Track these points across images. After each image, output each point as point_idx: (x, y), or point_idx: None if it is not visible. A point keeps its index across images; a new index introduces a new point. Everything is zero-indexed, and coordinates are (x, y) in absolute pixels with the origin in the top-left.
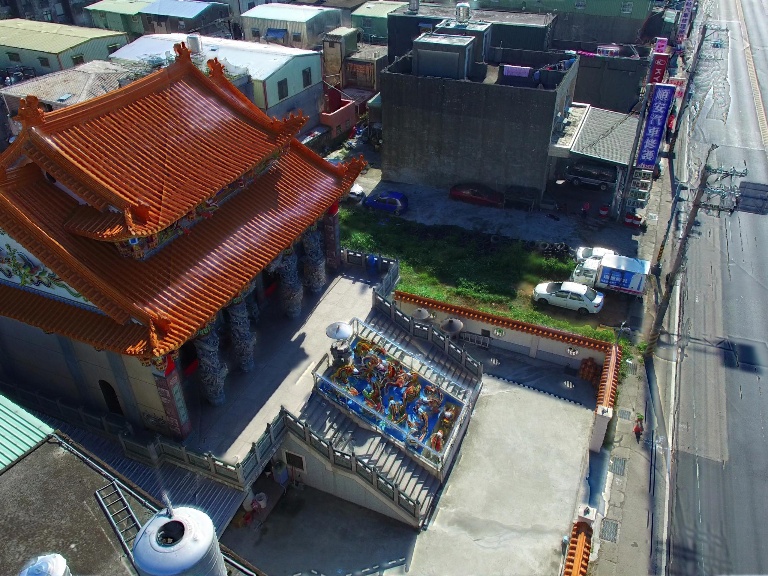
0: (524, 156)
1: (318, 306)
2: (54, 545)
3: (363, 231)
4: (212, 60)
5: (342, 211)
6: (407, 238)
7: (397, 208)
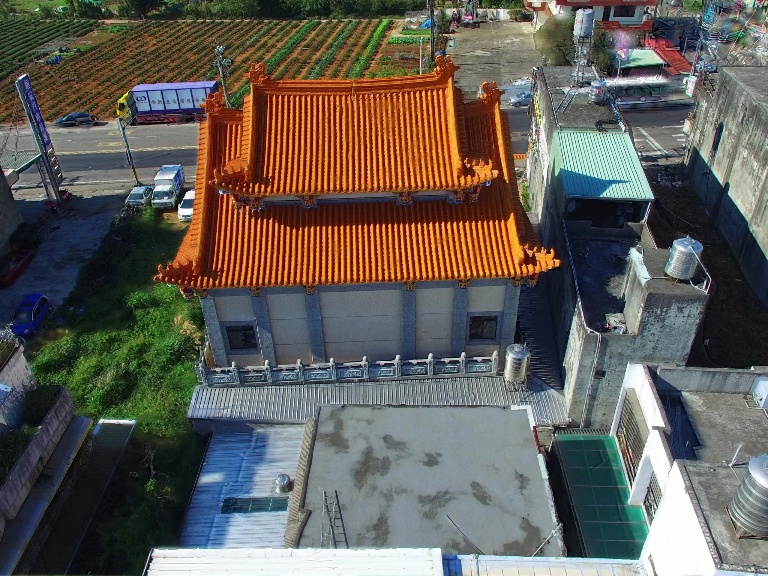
0: (0, 202)
1: None
2: None
3: (103, 316)
4: None
5: (51, 345)
6: (111, 290)
7: (49, 304)
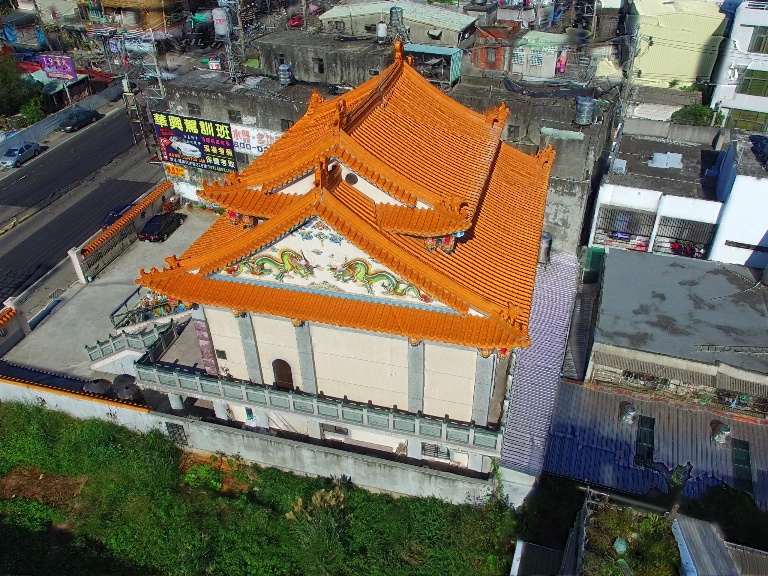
0: None
1: None
2: (299, 91)
3: None
4: (322, 157)
5: None
6: None
7: None
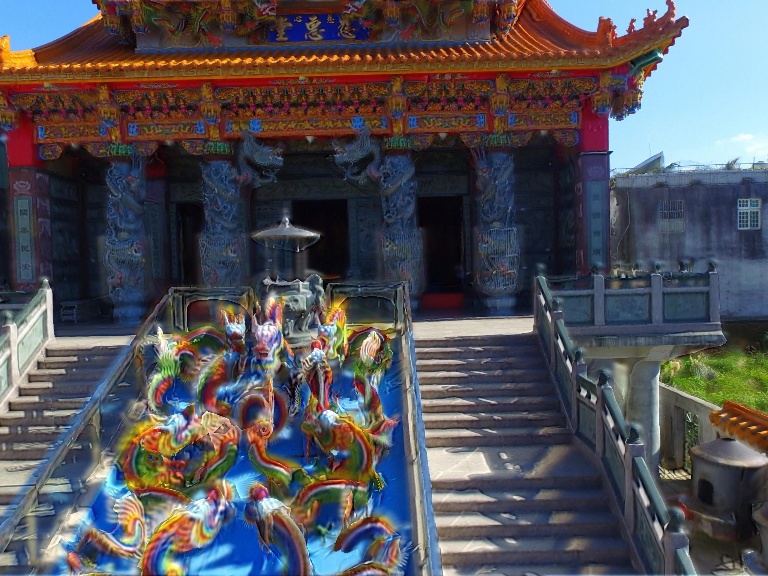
0: None
1: (458, 320)
2: None
3: None
4: None
5: None
6: None
7: None
